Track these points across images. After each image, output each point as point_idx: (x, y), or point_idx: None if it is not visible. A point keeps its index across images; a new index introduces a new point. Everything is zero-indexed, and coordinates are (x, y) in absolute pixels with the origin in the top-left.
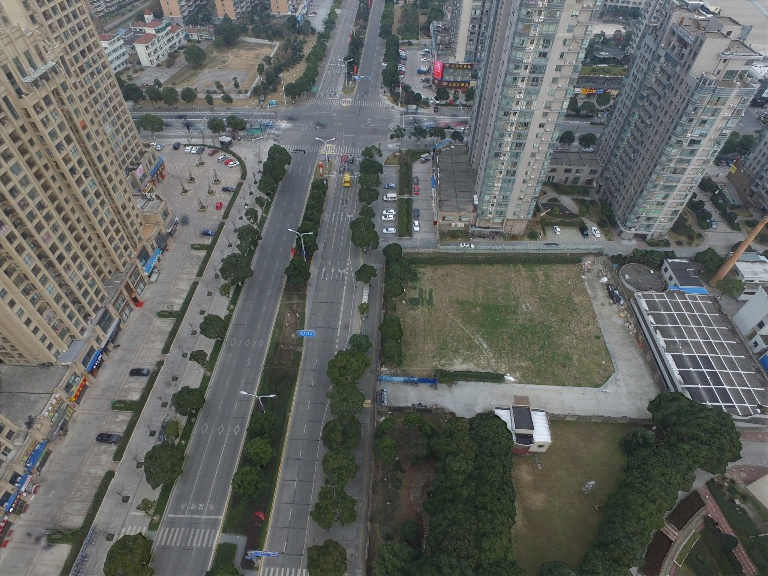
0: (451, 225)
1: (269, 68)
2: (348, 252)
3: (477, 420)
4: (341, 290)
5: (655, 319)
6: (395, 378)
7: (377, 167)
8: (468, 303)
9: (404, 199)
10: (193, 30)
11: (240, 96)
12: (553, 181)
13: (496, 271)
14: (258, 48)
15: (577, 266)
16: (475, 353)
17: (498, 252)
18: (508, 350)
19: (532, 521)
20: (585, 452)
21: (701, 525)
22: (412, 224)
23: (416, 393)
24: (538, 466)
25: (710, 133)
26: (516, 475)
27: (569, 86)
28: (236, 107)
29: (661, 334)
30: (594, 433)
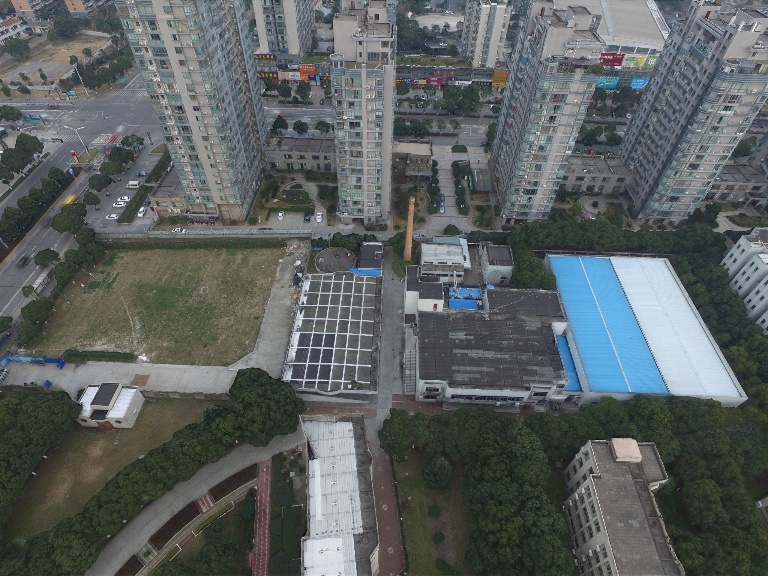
0: (168, 211)
1: (91, 60)
2: (59, 238)
3: (29, 395)
4: (28, 274)
5: (308, 300)
6: (22, 358)
7: (124, 155)
8: (147, 286)
9: (145, 186)
10: (36, 24)
11: (45, 88)
12: (307, 168)
13: (196, 255)
14: (95, 41)
15: (281, 250)
16: (123, 334)
17: (209, 237)
18: (158, 331)
19: (75, 494)
20: (171, 428)
21: (242, 497)
22: (138, 210)
23: (38, 373)
24: (115, 442)
25: (364, 115)
26: (87, 450)
27: (201, 68)
28: (36, 98)
29: (304, 314)
30: (192, 410)
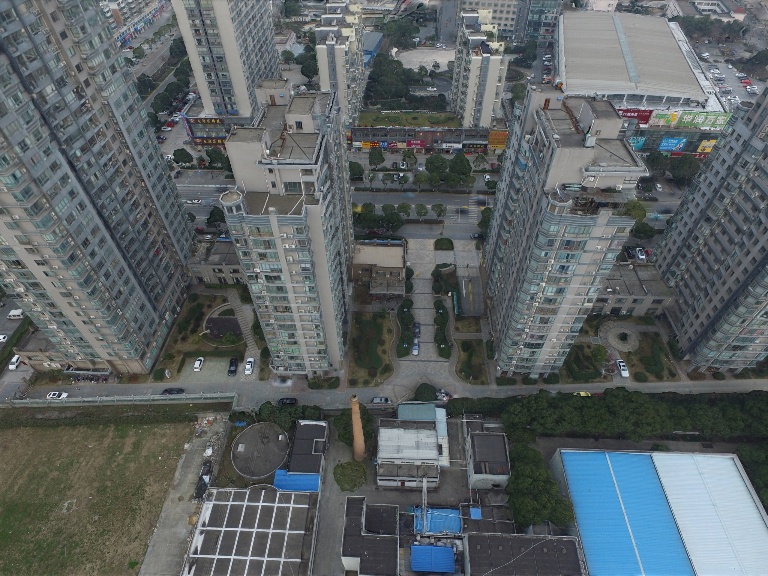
0: (44, 365)
1: None
2: None
3: None
4: None
5: (203, 543)
6: None
7: None
8: None
9: None
10: None
11: None
12: (244, 282)
13: (71, 438)
14: None
15: (190, 426)
16: None
17: (95, 404)
18: None
19: None
20: None
21: None
22: None
23: None
24: None
25: (284, 268)
26: None
27: (31, 217)
28: None
29: (193, 575)
30: None
